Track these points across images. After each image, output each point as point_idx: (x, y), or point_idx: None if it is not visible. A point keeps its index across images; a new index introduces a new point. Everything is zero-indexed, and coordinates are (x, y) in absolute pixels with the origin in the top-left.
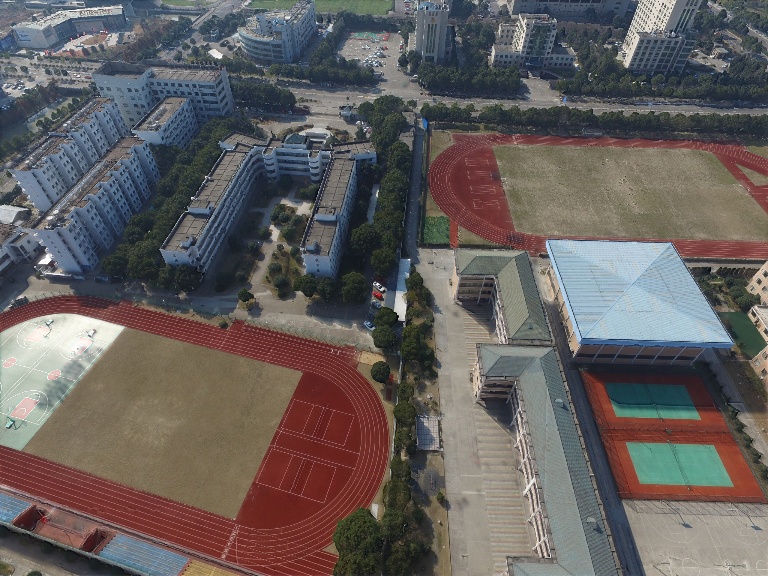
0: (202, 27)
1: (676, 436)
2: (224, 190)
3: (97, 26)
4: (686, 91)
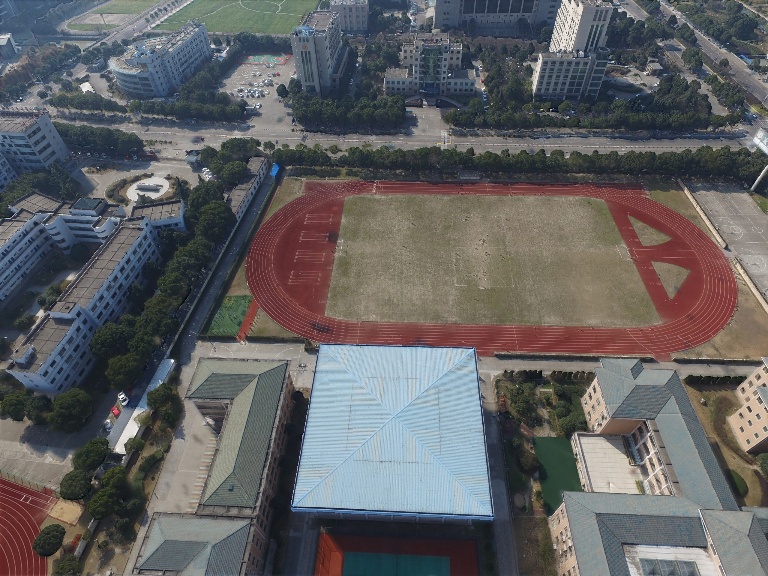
0: (83, 57)
1: None
2: None
3: None
4: (594, 121)
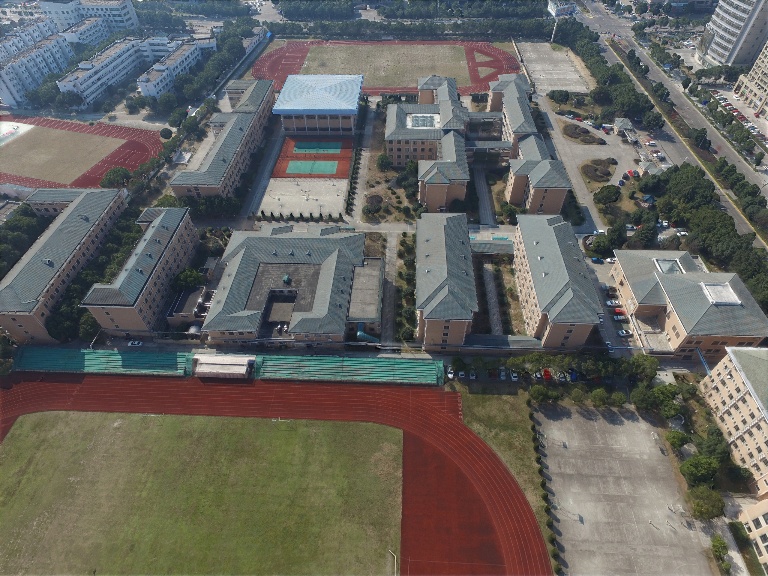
0: None
1: (320, 158)
2: (106, 59)
3: None
4: None
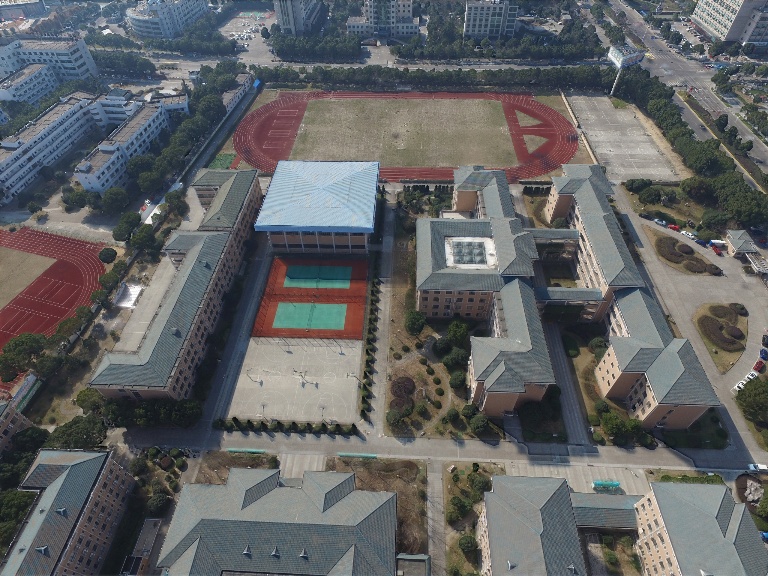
0: (104, 11)
1: (321, 299)
2: (40, 131)
3: (17, 13)
4: (505, 51)
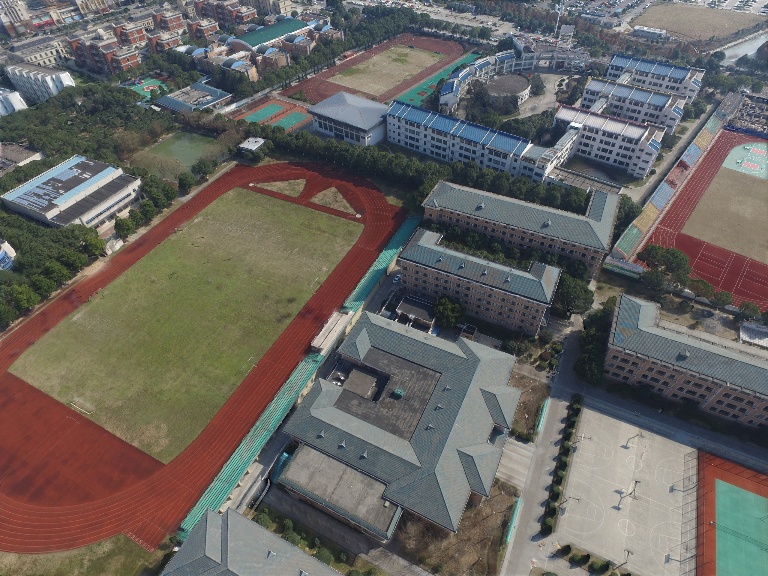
0: None
1: None
2: None
3: None
4: None
